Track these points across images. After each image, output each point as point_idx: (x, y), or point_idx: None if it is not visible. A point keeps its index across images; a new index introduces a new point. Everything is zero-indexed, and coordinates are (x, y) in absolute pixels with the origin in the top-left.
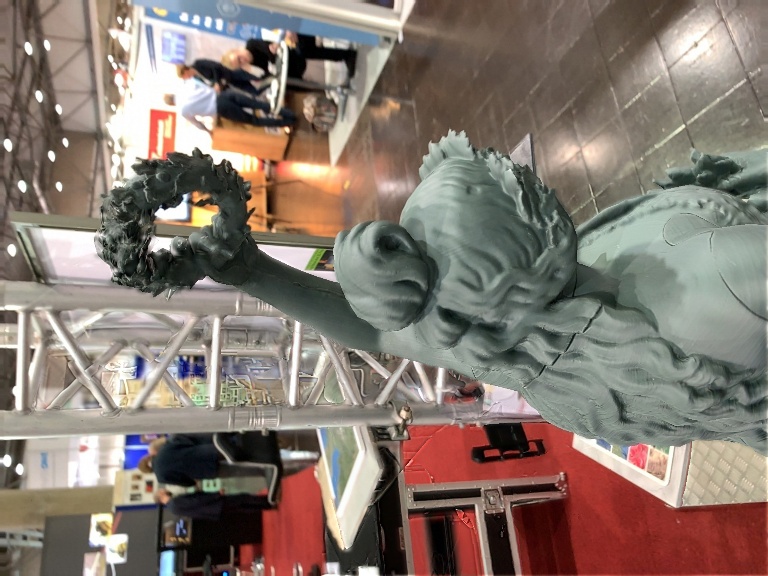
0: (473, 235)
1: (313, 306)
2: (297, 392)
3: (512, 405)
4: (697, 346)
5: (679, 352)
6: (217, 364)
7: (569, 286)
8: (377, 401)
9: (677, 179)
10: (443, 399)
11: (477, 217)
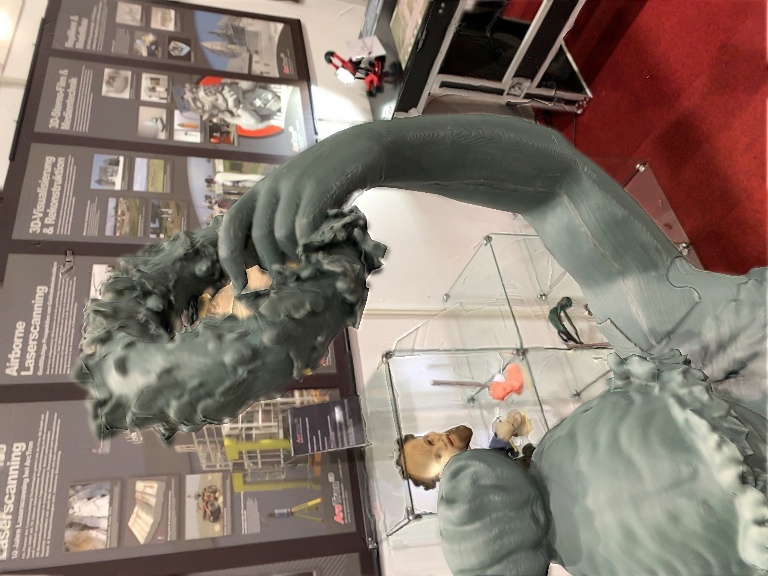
0: None
1: (447, 195)
2: None
3: None
4: None
5: None
6: None
7: None
8: None
9: None
10: None
11: None
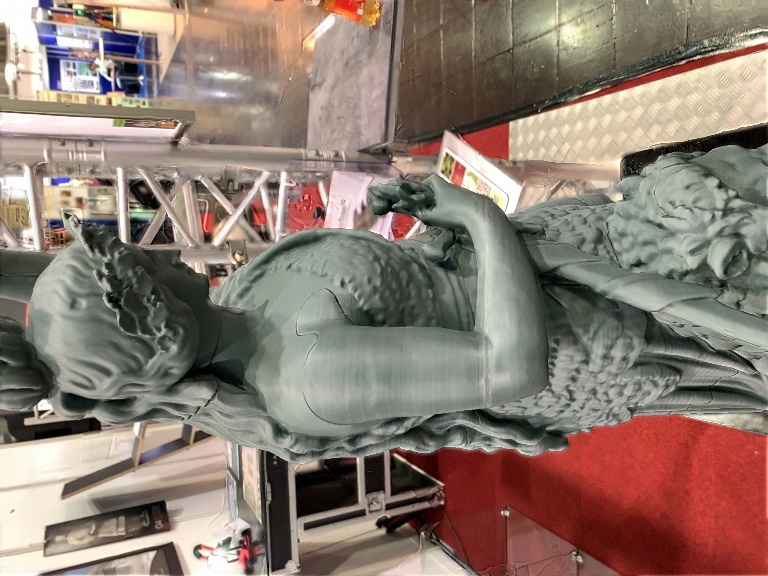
0: (76, 350)
1: (21, 291)
2: (128, 235)
3: None
4: (295, 428)
5: (283, 428)
6: (35, 210)
7: (207, 355)
8: (214, 242)
9: (385, 195)
10: None
11: (78, 334)
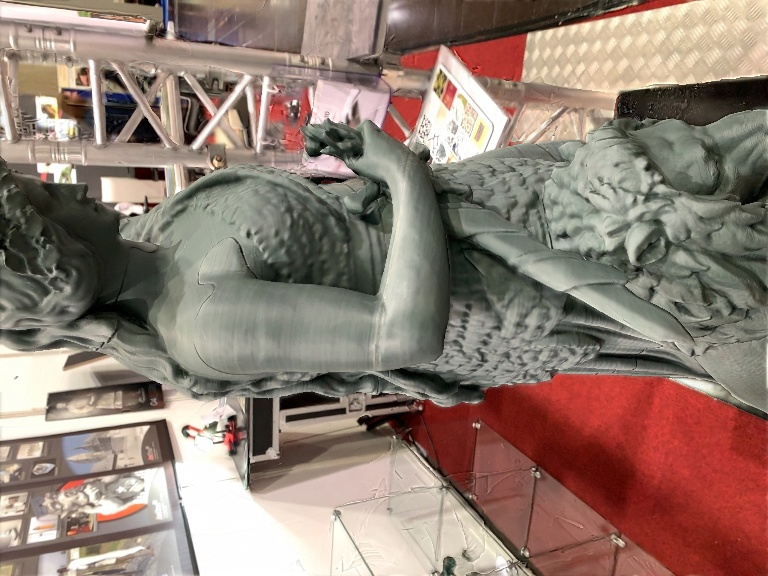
0: None
1: None
2: (102, 131)
3: (328, 165)
4: (193, 371)
5: (183, 369)
6: (4, 99)
7: (112, 293)
8: (192, 144)
9: (315, 137)
10: (262, 148)
11: None
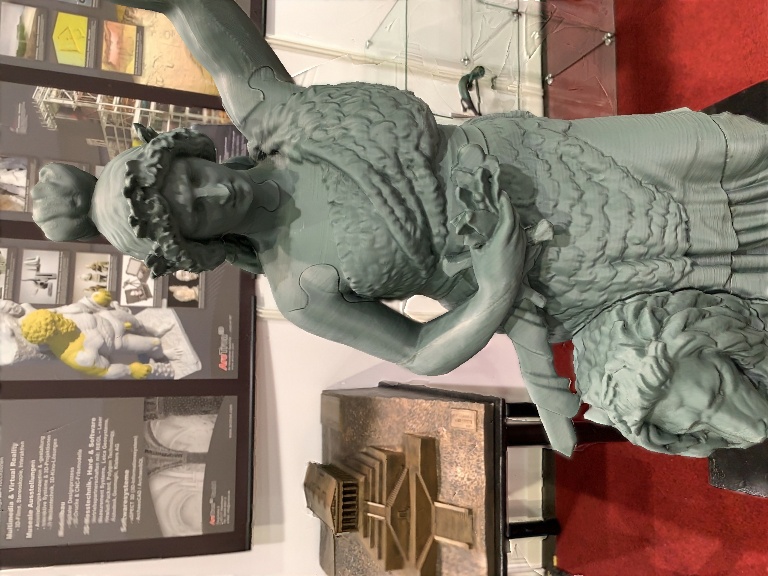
0: None
1: None
2: None
3: None
4: None
5: None
6: None
7: None
8: None
9: None
10: None
11: None
